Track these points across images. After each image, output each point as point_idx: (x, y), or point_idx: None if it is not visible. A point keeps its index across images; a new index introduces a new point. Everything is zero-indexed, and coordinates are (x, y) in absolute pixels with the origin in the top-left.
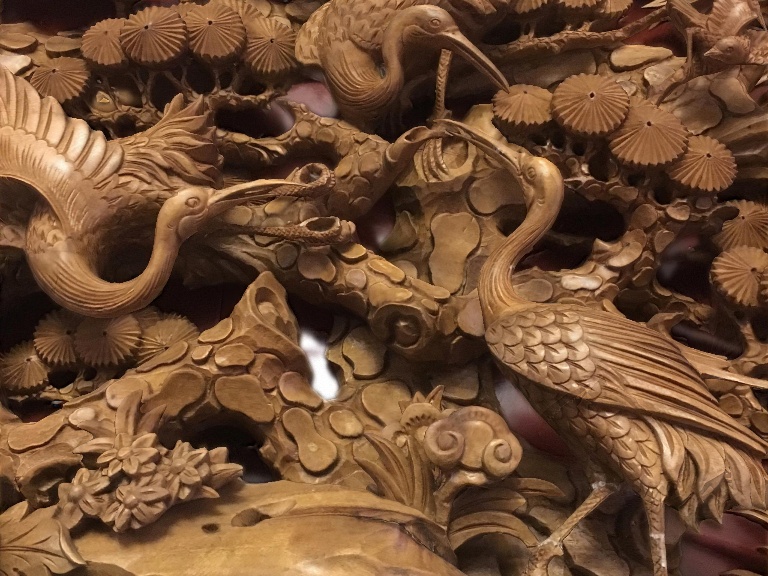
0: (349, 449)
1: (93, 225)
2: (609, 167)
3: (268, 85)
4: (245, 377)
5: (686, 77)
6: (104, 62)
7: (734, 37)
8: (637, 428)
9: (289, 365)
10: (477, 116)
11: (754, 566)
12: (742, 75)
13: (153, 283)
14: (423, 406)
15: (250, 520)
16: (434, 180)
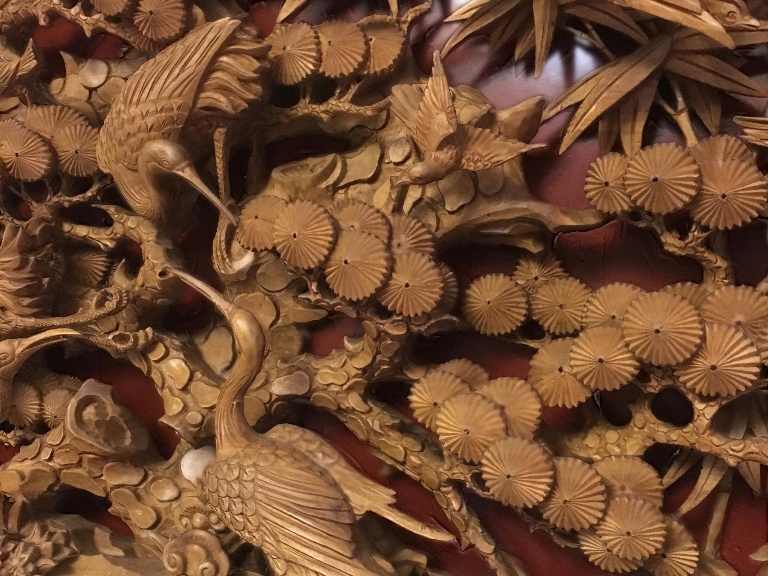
0: (169, 510)
1: None
2: None
3: (94, 179)
4: (77, 472)
5: None
6: None
7: (434, 153)
8: (291, 571)
9: (109, 458)
10: (272, 186)
11: None
12: None
13: None
14: (192, 501)
15: None
16: (223, 272)
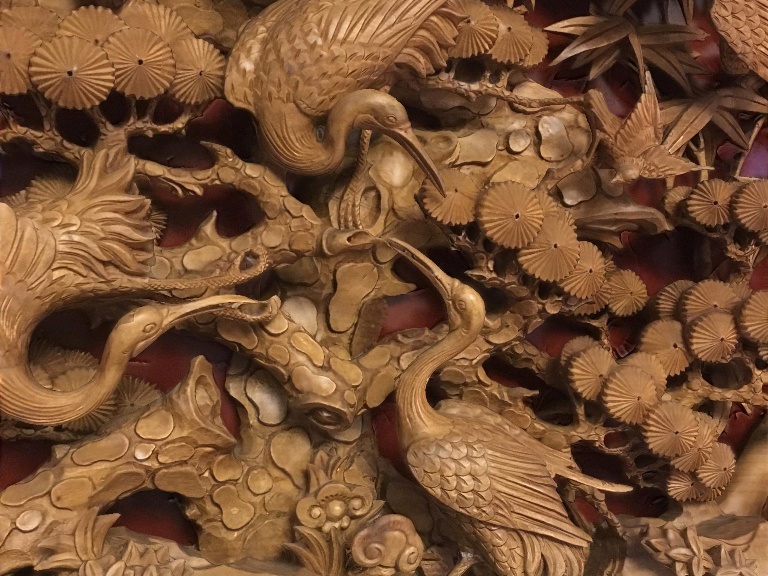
0: (262, 503)
1: (26, 326)
2: (510, 264)
3: (185, 108)
4: (185, 470)
5: None
6: (5, 90)
7: (635, 159)
8: (512, 539)
9: (221, 450)
10: (387, 152)
11: None
12: None
13: (103, 401)
14: (338, 488)
15: None
16: None
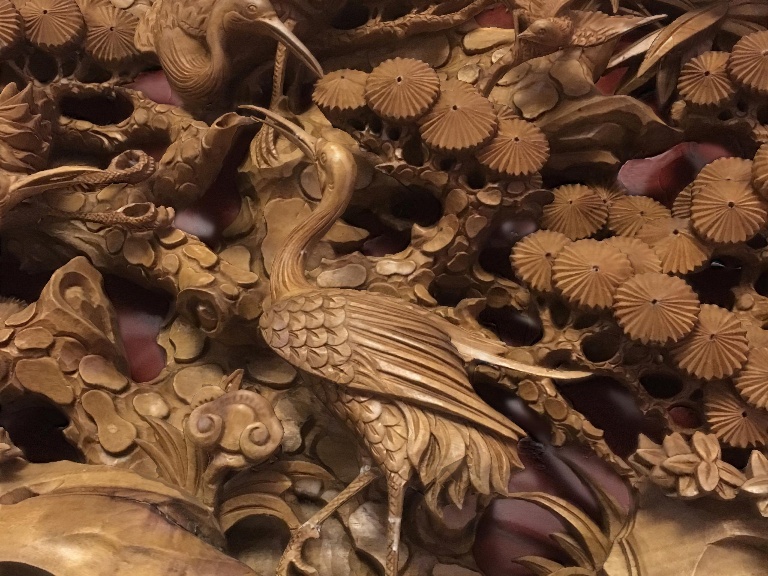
0: (152, 431)
1: None
2: (423, 152)
3: (113, 73)
4: (44, 360)
5: (514, 60)
6: None
7: (552, 18)
8: (388, 413)
9: (91, 348)
10: None
11: (548, 553)
12: (585, 57)
13: None
14: (212, 389)
15: (23, 498)
16: (265, 166)
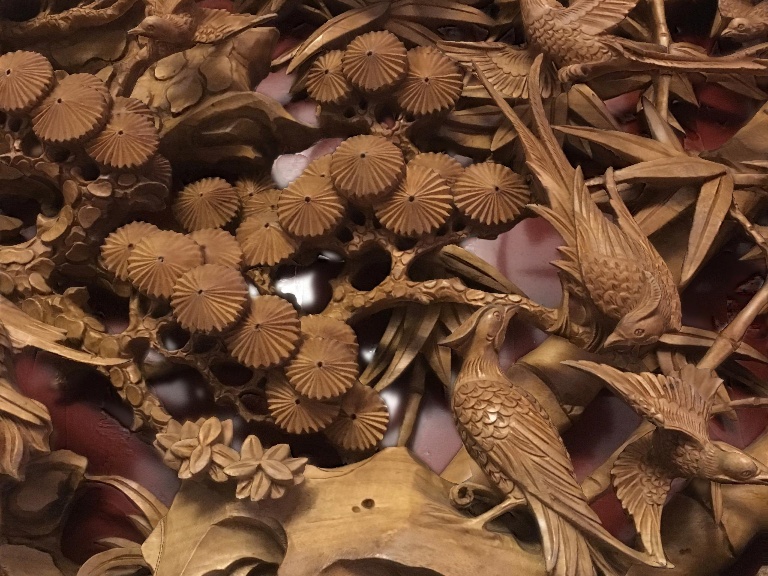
0: None
1: None
2: None
3: None
4: None
5: (149, 55)
6: None
7: (169, 15)
8: None
9: None
10: None
11: (132, 534)
12: (236, 53)
13: None
14: None
15: None
16: None
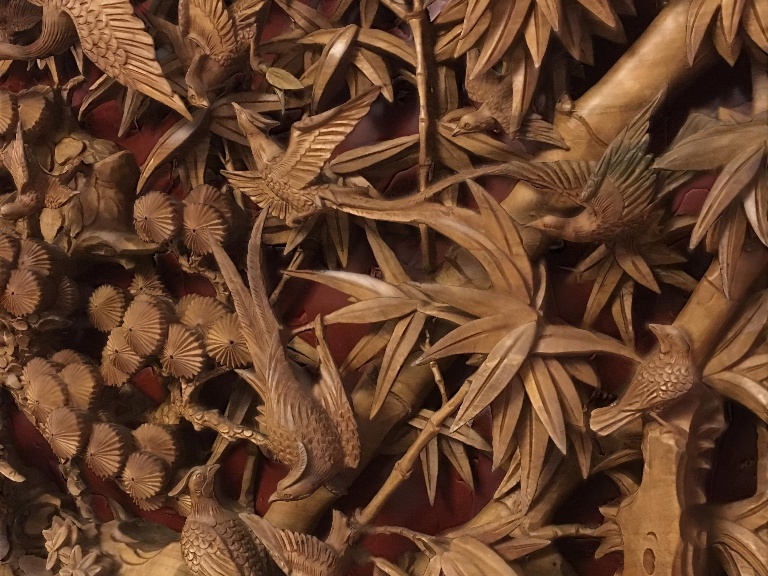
0: None
1: None
2: None
3: None
4: None
5: None
6: None
7: (20, 197)
8: None
9: None
10: None
11: None
12: (100, 182)
13: None
14: None
15: None
16: None
